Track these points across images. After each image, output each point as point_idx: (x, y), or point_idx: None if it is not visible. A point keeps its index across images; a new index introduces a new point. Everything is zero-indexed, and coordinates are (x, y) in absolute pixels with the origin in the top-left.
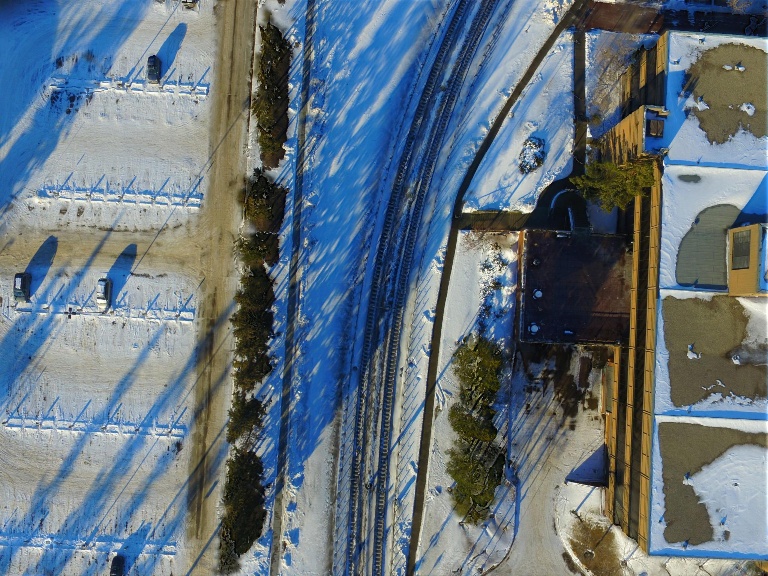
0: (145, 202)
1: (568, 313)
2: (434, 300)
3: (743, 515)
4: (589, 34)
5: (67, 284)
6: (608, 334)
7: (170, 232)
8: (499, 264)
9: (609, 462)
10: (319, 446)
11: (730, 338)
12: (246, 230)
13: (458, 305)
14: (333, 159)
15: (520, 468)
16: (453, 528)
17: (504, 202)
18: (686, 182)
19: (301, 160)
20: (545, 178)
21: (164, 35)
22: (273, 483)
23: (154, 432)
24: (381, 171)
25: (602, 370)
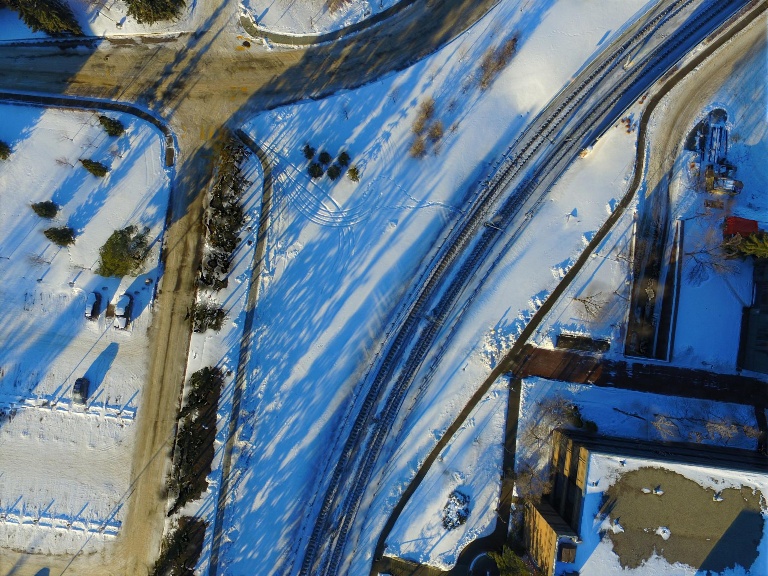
0: (61, 526)
1: None
2: None
3: None
4: (525, 382)
5: None
6: None
7: (85, 558)
8: None
9: None
10: None
11: None
12: (162, 564)
13: None
14: (256, 494)
15: None
16: None
17: (425, 555)
18: None
19: (224, 493)
20: (467, 537)
21: (94, 354)
22: None
23: None
24: (305, 508)
25: None
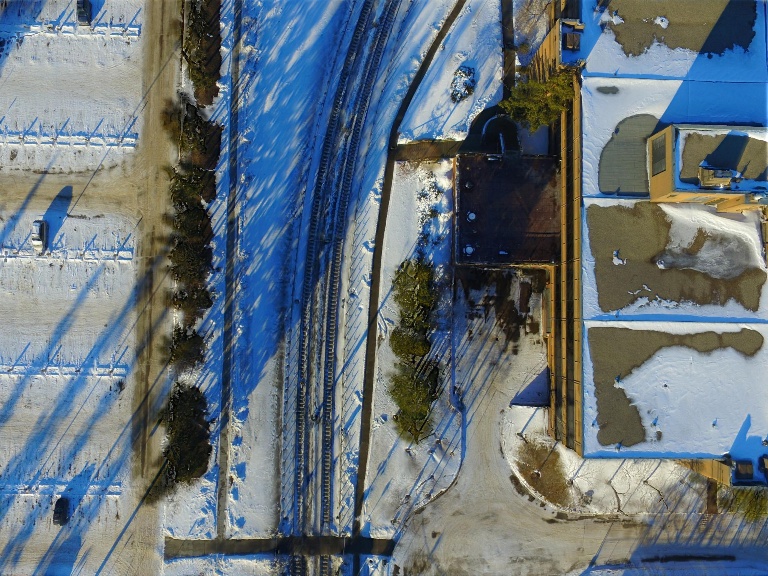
0: (79, 143)
1: (502, 235)
2: (373, 231)
3: (674, 415)
4: None
5: (2, 228)
6: (542, 254)
7: (106, 173)
8: (435, 192)
9: (550, 382)
10: (263, 379)
11: (654, 244)
12: (182, 167)
13: (397, 235)
14: (267, 95)
15: (465, 394)
16: (400, 455)
17: (437, 131)
18: (605, 94)
19: (235, 97)
20: (476, 105)
21: None
22: (218, 418)
23: (95, 372)
24: (316, 106)
25: (542, 294)
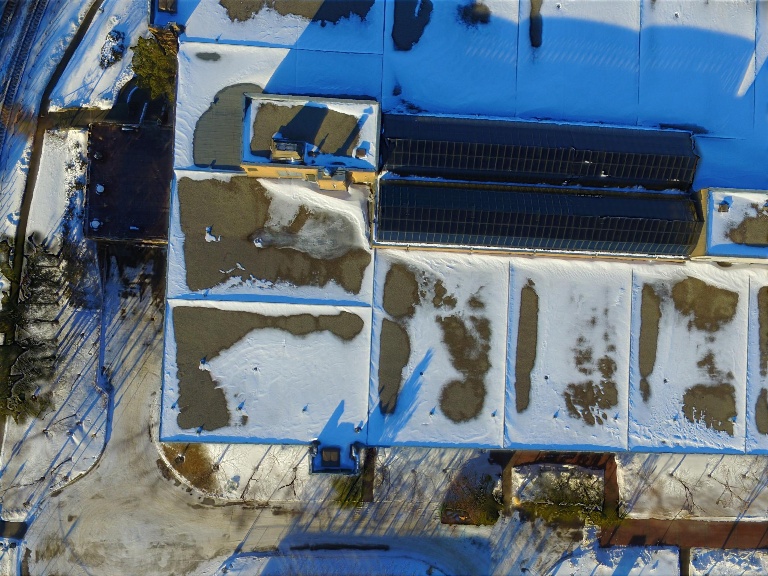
0: None
1: (136, 209)
2: (17, 202)
3: (263, 400)
4: None
5: None
6: None
7: None
8: (79, 163)
9: None
10: None
11: (251, 221)
12: None
13: (42, 207)
14: None
15: (114, 375)
16: (36, 436)
17: (85, 99)
18: (204, 60)
19: None
20: (124, 72)
21: None
22: None
23: None
24: None
25: None
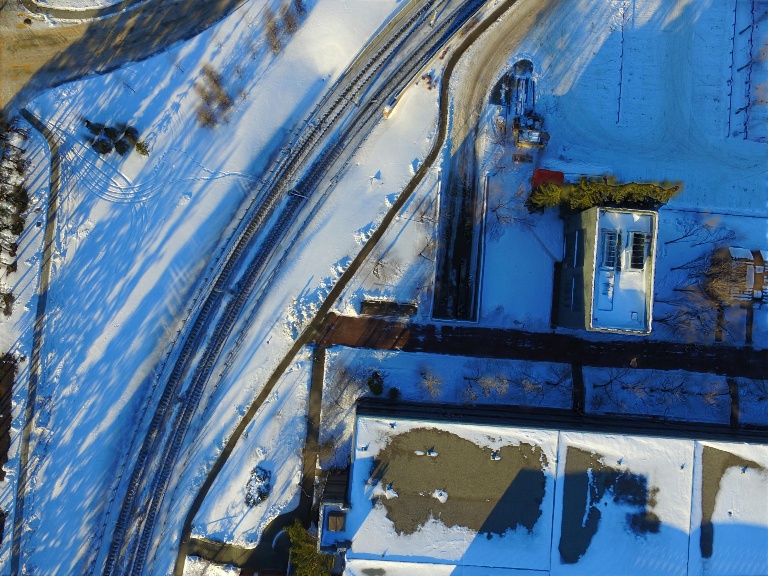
0: None
1: None
2: None
3: None
4: (329, 351)
5: None
6: None
7: None
8: None
9: None
10: None
11: None
12: None
13: None
14: (56, 481)
15: None
16: None
17: (229, 534)
18: None
19: (23, 481)
20: (269, 513)
21: None
22: None
23: None
24: (107, 492)
25: None
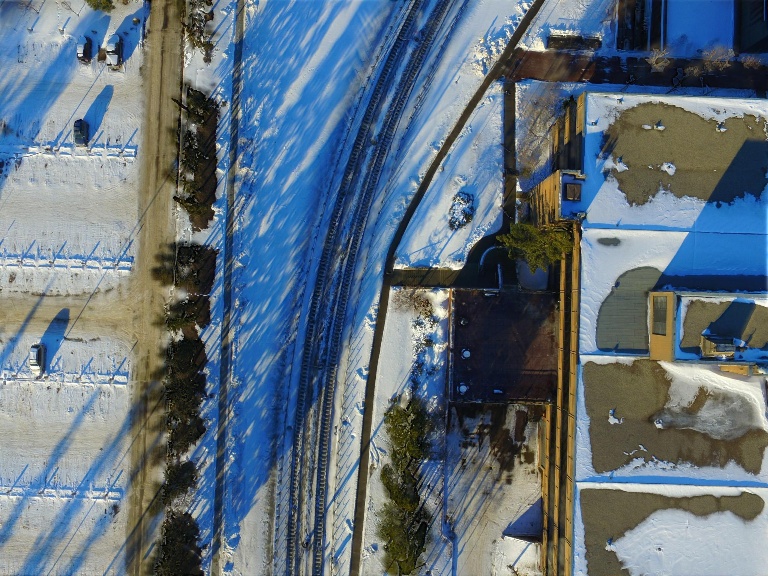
0: (76, 266)
1: (498, 372)
2: (367, 358)
3: None
4: (519, 84)
5: (1, 350)
6: (538, 392)
7: (102, 296)
8: (430, 321)
9: (543, 518)
10: (254, 506)
11: (652, 402)
12: (177, 292)
13: (391, 362)
14: (263, 218)
15: (457, 523)
16: None
17: (434, 259)
18: (605, 245)
19: (231, 220)
20: (474, 234)
21: (91, 98)
22: (209, 544)
23: (91, 495)
24: (311, 229)
25: (538, 423)
